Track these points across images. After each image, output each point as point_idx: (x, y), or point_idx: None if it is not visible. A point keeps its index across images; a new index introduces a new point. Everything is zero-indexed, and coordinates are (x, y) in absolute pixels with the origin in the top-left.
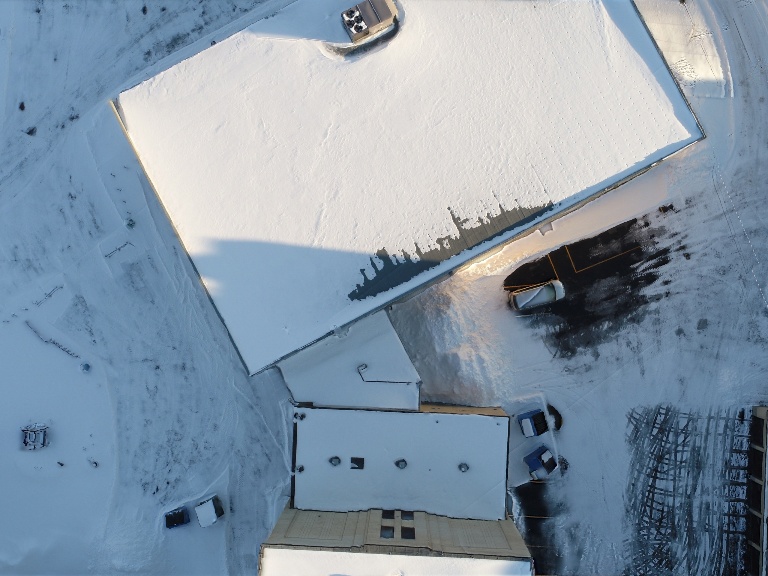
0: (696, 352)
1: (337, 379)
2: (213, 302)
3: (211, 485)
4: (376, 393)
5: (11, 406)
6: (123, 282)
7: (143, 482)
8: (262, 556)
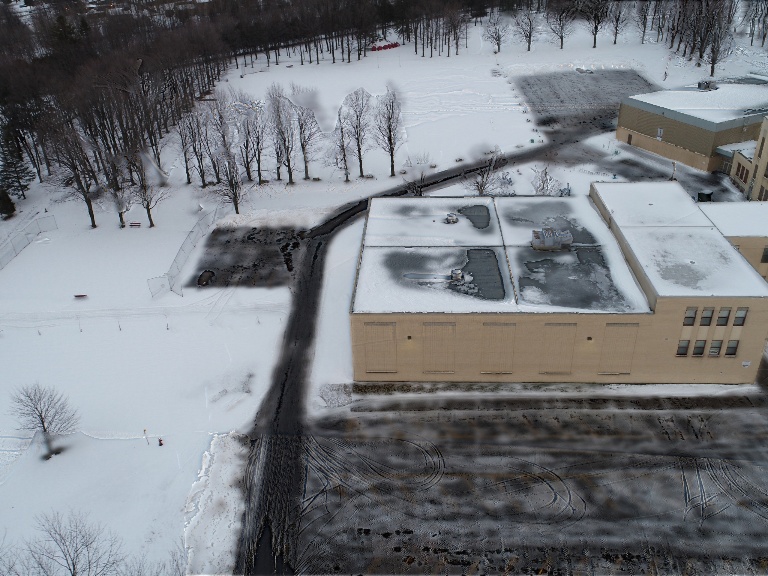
0: None
1: None
2: (690, 115)
3: None
4: None
5: None
6: None
7: None
8: None
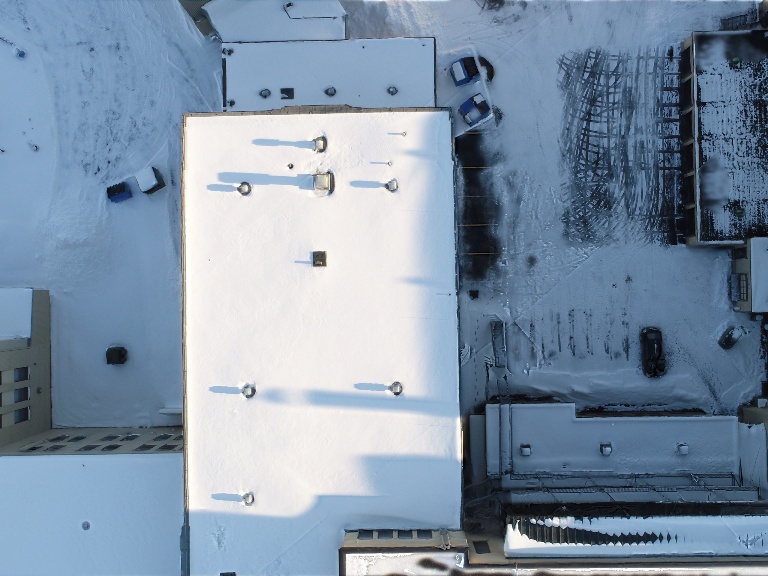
0: None
1: (264, 18)
2: None
3: (151, 160)
4: (303, 29)
5: None
6: None
7: (84, 163)
8: (185, 125)
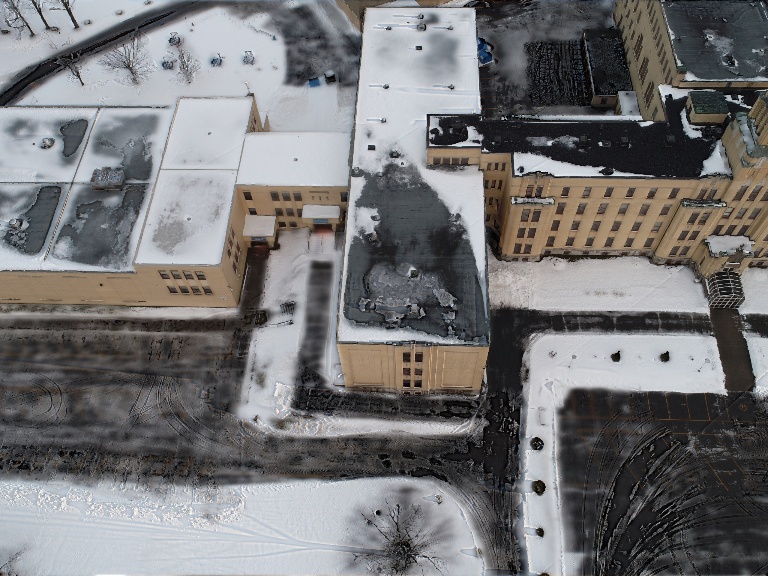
0: (552, 25)
1: None
2: None
3: None
4: None
5: (239, 51)
6: (294, 14)
7: (298, 75)
8: (366, 10)
